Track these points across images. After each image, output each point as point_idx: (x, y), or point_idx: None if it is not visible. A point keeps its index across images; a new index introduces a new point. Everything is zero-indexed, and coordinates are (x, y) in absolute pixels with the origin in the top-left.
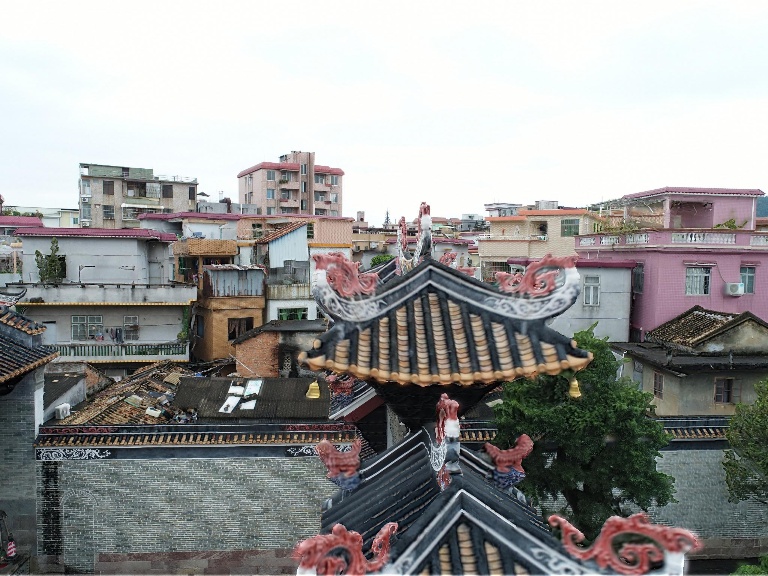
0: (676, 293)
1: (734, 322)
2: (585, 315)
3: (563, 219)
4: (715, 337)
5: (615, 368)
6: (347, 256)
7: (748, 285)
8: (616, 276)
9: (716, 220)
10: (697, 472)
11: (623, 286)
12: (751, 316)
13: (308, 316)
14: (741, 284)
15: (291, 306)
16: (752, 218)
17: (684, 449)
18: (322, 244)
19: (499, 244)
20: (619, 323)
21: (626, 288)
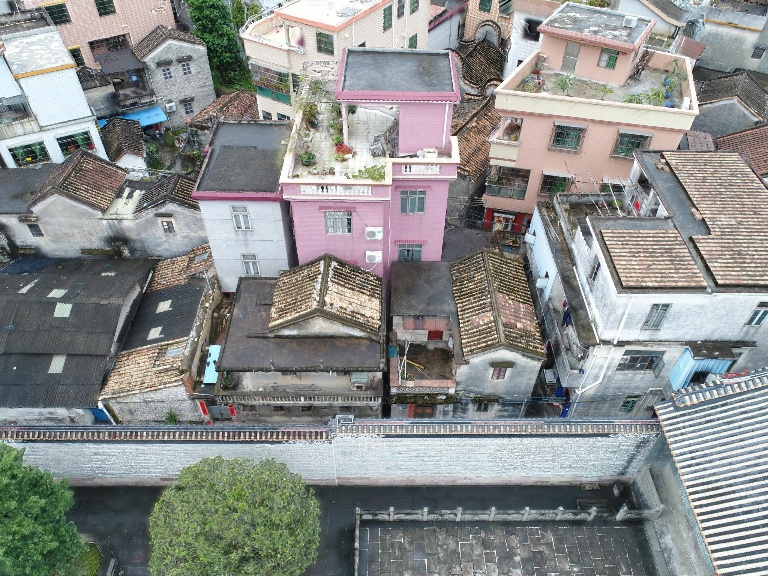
0: (316, 233)
1: (305, 316)
2: (239, 238)
3: (318, 31)
4: (287, 326)
5: (7, 508)
6: (73, 77)
7: (418, 205)
8: (264, 206)
9: (402, 126)
10: (220, 453)
11: (273, 215)
12: (321, 312)
13: (48, 146)
14: (378, 231)
15: (23, 141)
16: (445, 124)
17: (204, 443)
18: (33, 72)
19: (260, 46)
20: (275, 244)
21: (277, 216)
